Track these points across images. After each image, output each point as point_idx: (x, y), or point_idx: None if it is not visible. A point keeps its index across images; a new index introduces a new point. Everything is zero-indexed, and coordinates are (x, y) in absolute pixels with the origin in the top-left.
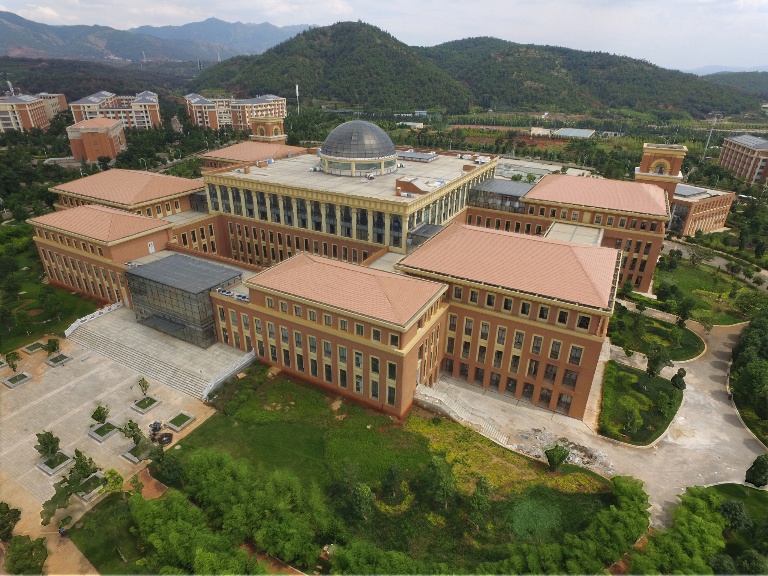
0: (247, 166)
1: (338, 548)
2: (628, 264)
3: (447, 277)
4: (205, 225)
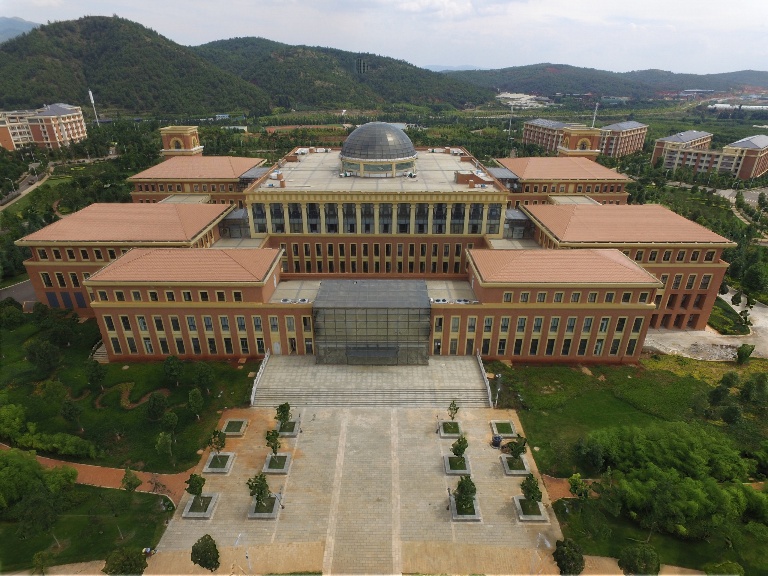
0: (282, 179)
1: (762, 452)
2: None
3: (611, 244)
4: None
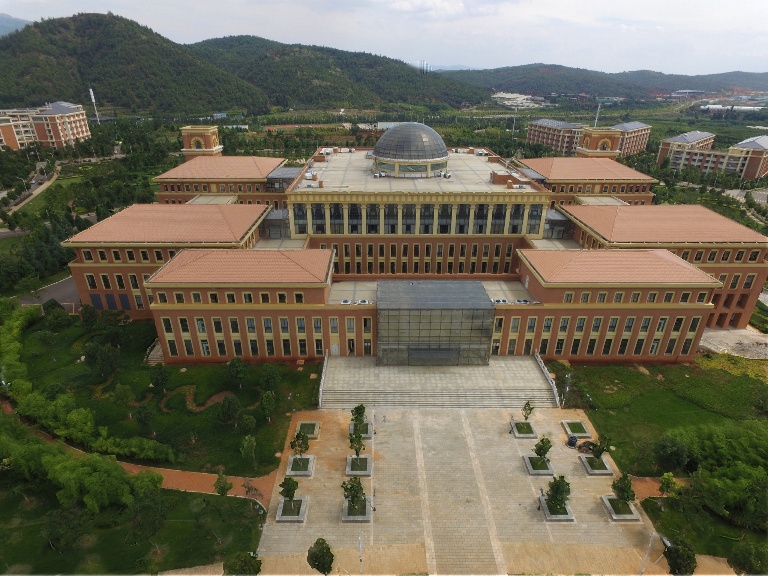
0: None
1: None
2: None
3: (659, 244)
4: None
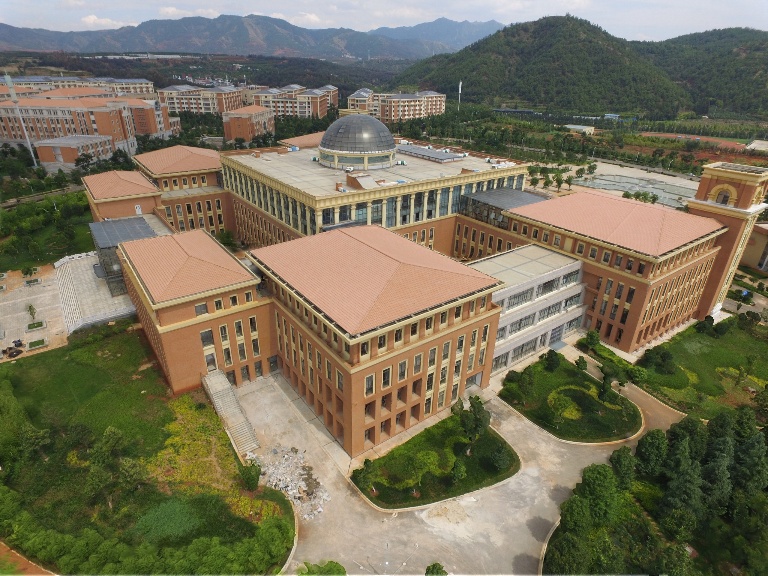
0: (258, 151)
1: None
2: (608, 311)
3: (267, 271)
4: (212, 199)
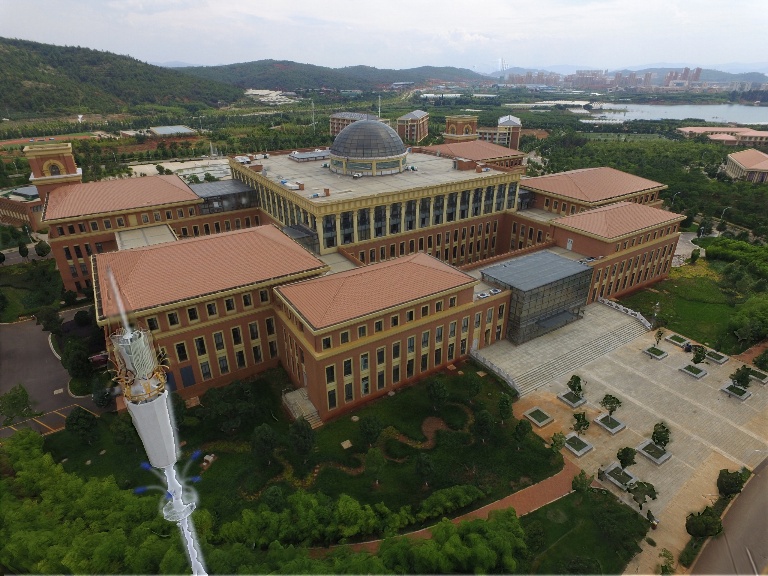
0: None
1: None
2: None
3: (616, 198)
4: None
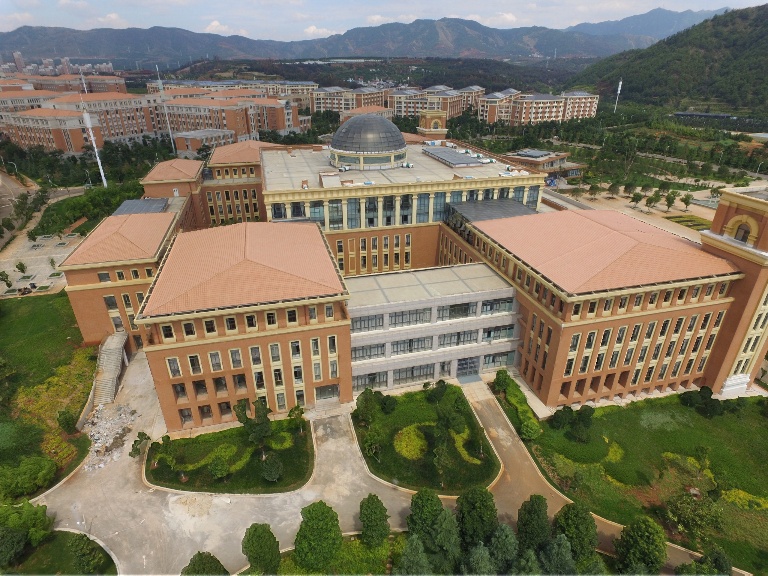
0: None
1: None
2: (532, 351)
3: None
4: (248, 189)
